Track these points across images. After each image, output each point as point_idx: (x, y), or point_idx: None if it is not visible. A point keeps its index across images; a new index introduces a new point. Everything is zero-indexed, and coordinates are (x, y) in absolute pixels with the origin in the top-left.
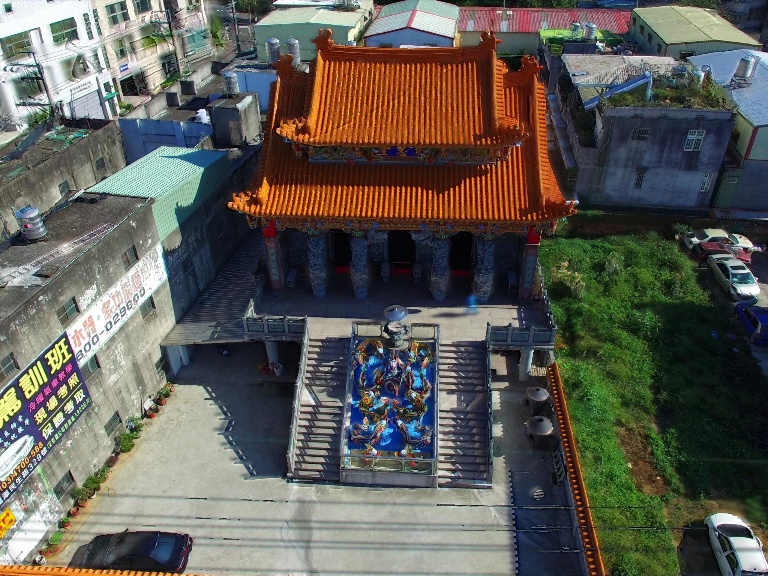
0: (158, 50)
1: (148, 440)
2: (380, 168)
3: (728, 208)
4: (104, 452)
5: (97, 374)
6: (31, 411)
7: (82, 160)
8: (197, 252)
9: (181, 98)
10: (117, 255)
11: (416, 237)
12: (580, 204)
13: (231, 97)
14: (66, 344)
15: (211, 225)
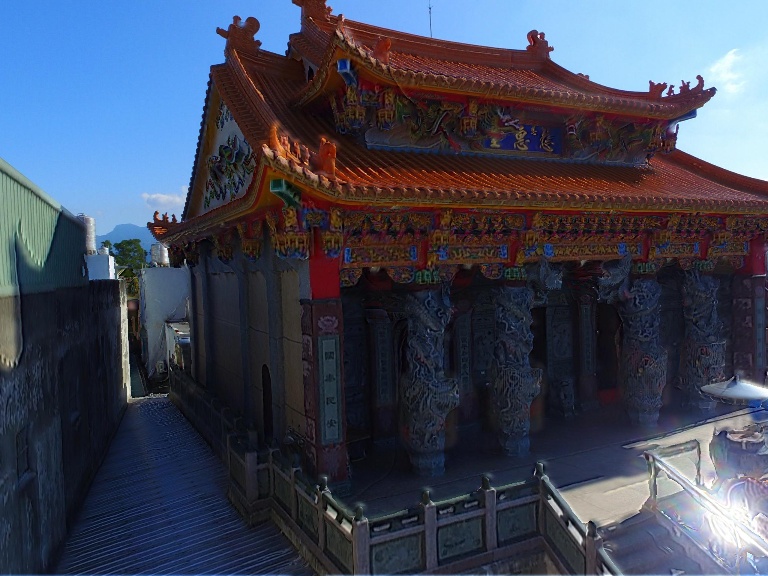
0: None
1: None
2: (503, 161)
3: None
4: None
5: None
6: None
7: None
8: (41, 428)
9: None
10: None
11: (608, 279)
12: None
13: None
14: None
15: (62, 372)
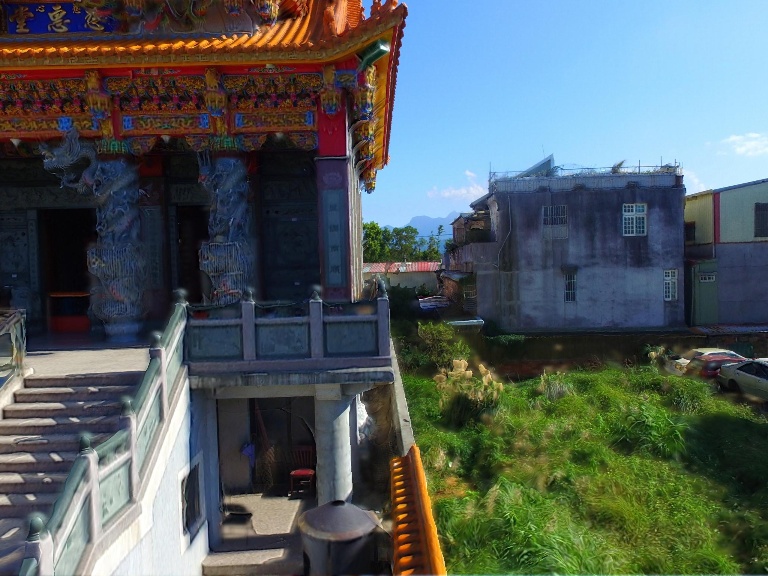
0: None
1: None
2: (1, 43)
3: (715, 325)
4: None
5: None
6: None
7: None
8: None
9: None
10: None
11: (53, 161)
12: (487, 330)
13: None
14: None
15: None
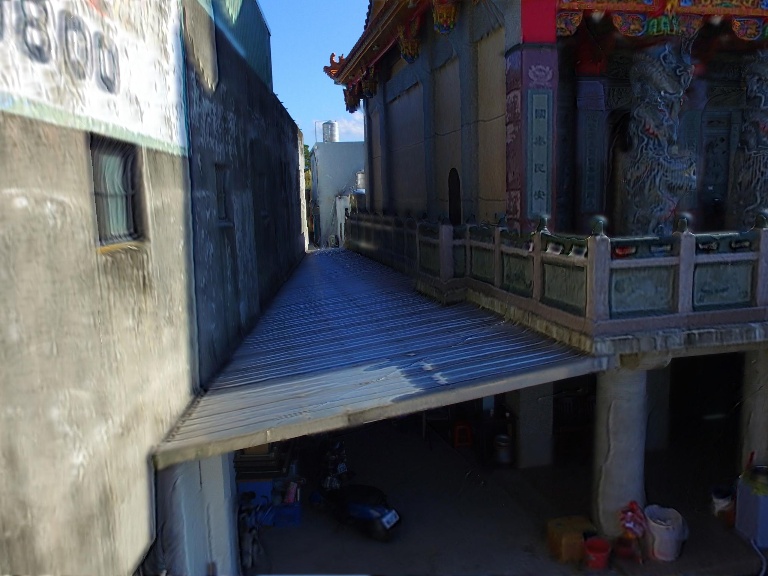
0: None
1: None
2: None
3: None
4: None
5: None
6: None
7: None
8: (236, 187)
9: None
10: None
11: None
12: None
13: None
14: None
15: (253, 155)
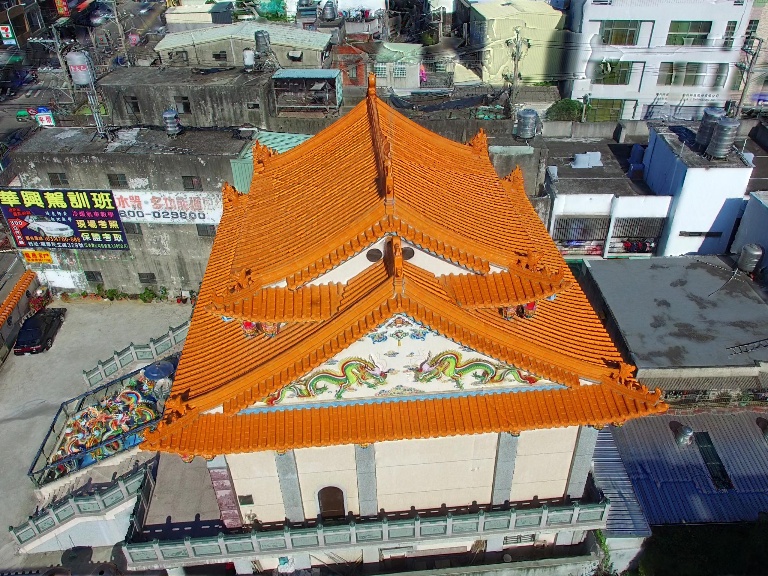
0: (727, 83)
1: (155, 307)
2: None
3: None
4: (135, 287)
5: (139, 236)
6: (75, 216)
7: (451, 136)
8: None
9: (645, 138)
10: (177, 173)
11: None
12: None
13: (516, 138)
14: (111, 198)
15: None
